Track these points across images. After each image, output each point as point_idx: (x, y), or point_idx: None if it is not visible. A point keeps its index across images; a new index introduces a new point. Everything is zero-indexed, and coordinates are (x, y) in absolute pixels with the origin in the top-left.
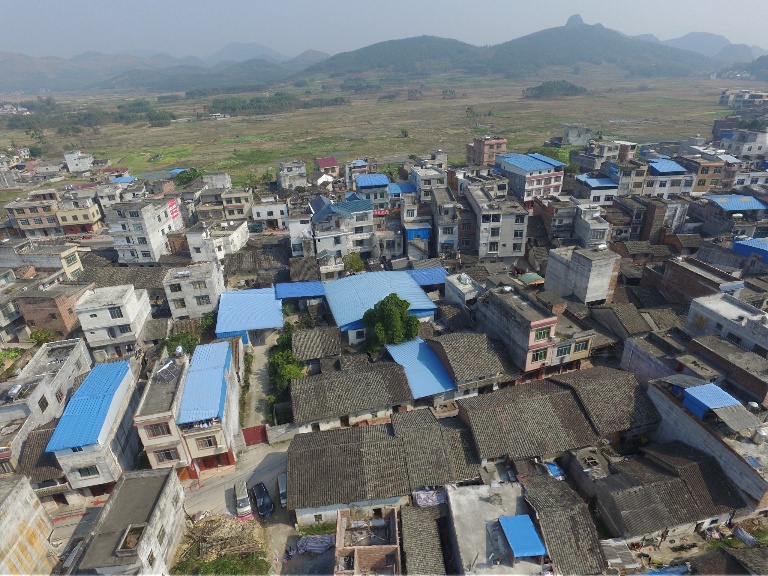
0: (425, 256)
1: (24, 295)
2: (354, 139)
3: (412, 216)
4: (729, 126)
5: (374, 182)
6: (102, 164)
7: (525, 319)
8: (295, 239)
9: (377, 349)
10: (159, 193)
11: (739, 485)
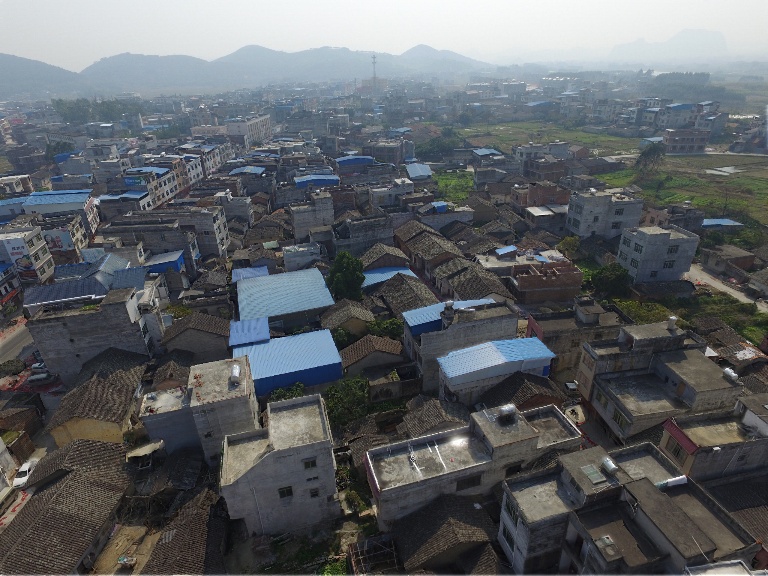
0: (188, 282)
1: None
2: None
3: (141, 256)
4: (23, 154)
5: None
6: None
7: (389, 219)
8: (141, 320)
9: None
10: None
11: (466, 221)
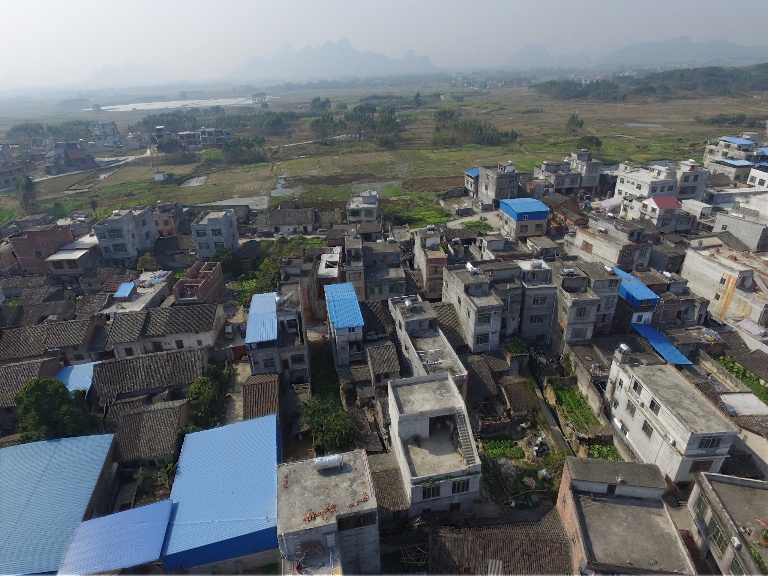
0: None
1: (641, 466)
2: None
3: None
4: None
5: None
6: None
7: None
8: None
9: None
10: None
11: (0, 304)
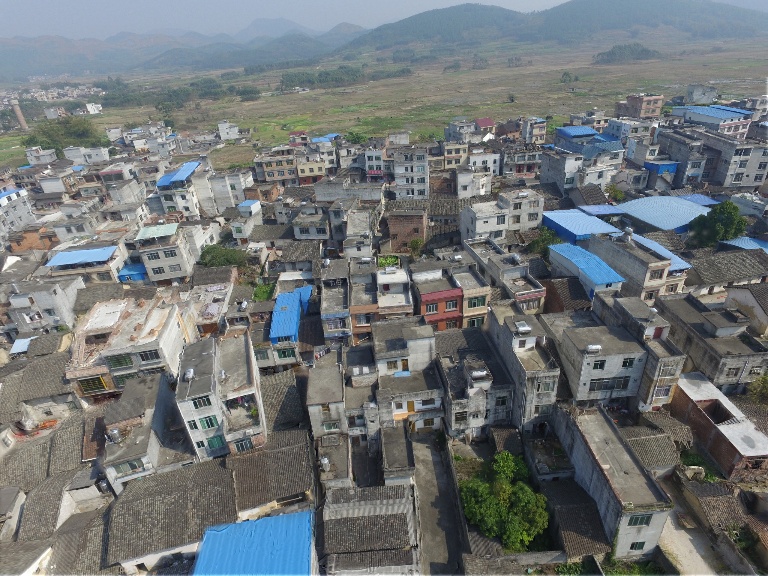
0: (669, 188)
1: (395, 214)
2: (461, 106)
3: (653, 155)
4: None
5: (584, 132)
6: (245, 133)
7: None
8: (570, 173)
9: (712, 244)
10: (384, 147)
11: None
